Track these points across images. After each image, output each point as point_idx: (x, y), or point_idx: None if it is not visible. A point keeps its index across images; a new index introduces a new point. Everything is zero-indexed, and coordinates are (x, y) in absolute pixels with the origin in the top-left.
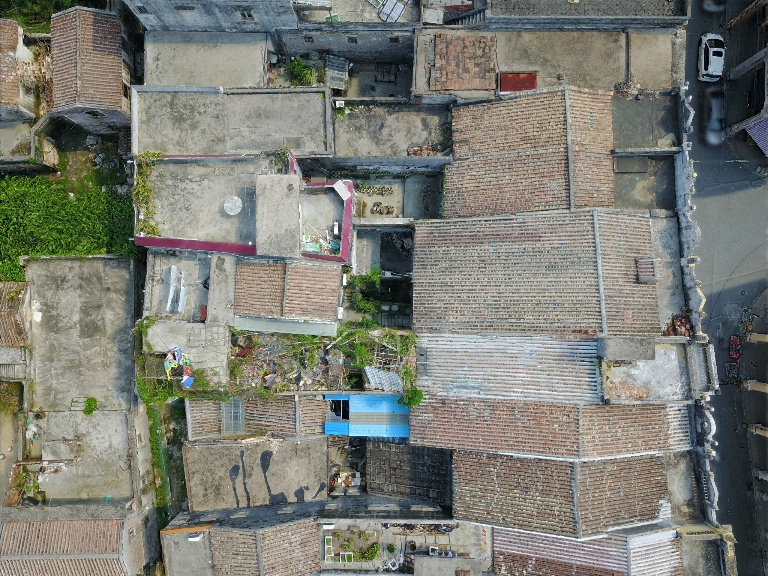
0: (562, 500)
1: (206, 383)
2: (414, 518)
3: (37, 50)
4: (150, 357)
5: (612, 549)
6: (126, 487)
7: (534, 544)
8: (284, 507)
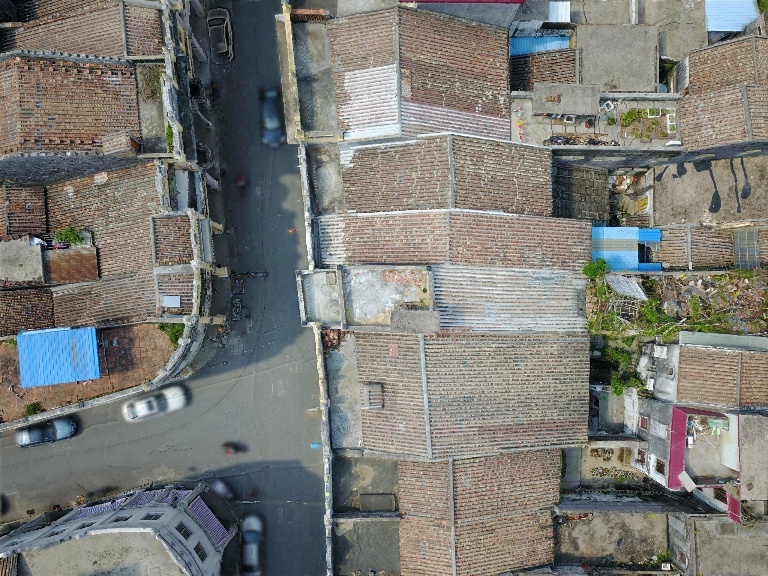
0: (463, 171)
1: None
2: None
3: None
4: None
5: (414, 123)
6: None
7: (477, 126)
8: None
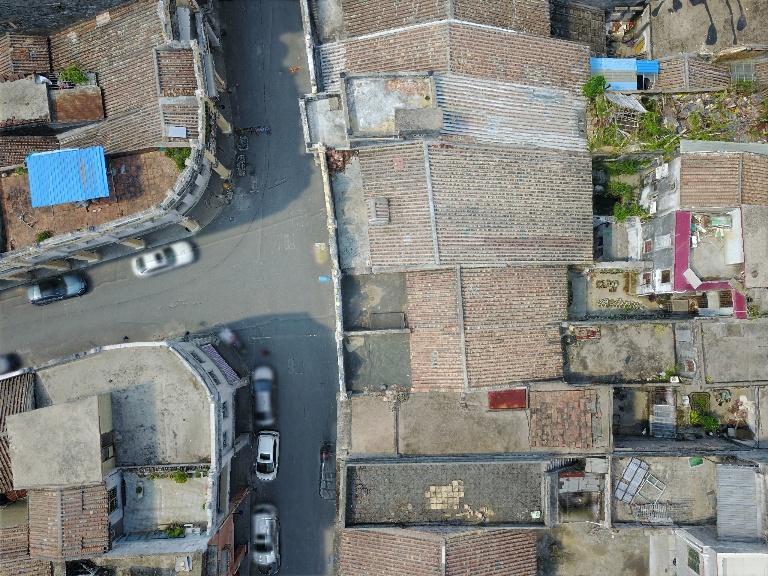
0: None
1: None
2: None
3: None
4: None
5: None
6: None
7: None
8: None
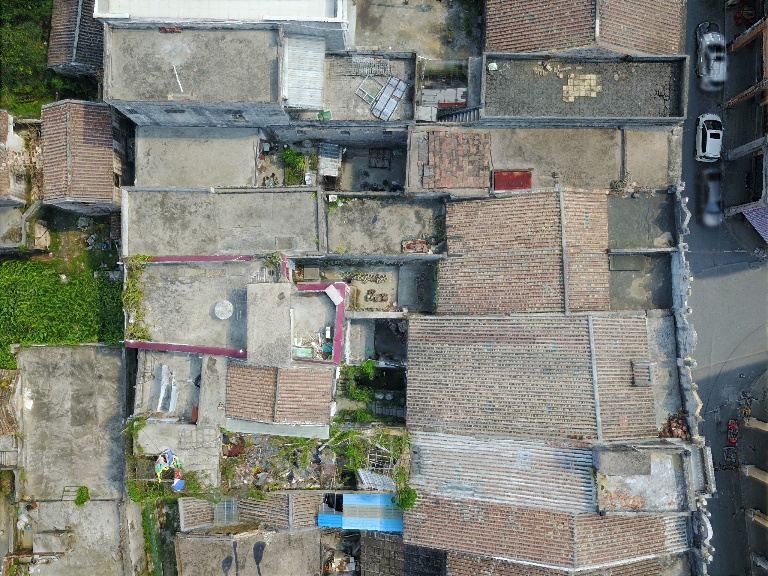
0: None
1: (197, 486)
2: None
3: (28, 135)
4: (141, 459)
5: None
6: None
7: None
8: None
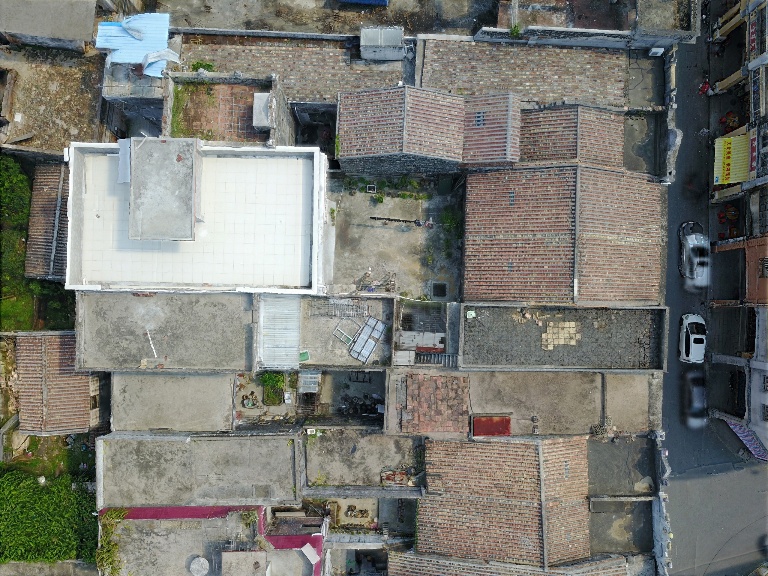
0: None
1: None
2: None
3: (5, 346)
4: None
5: None
6: None
7: None
8: None
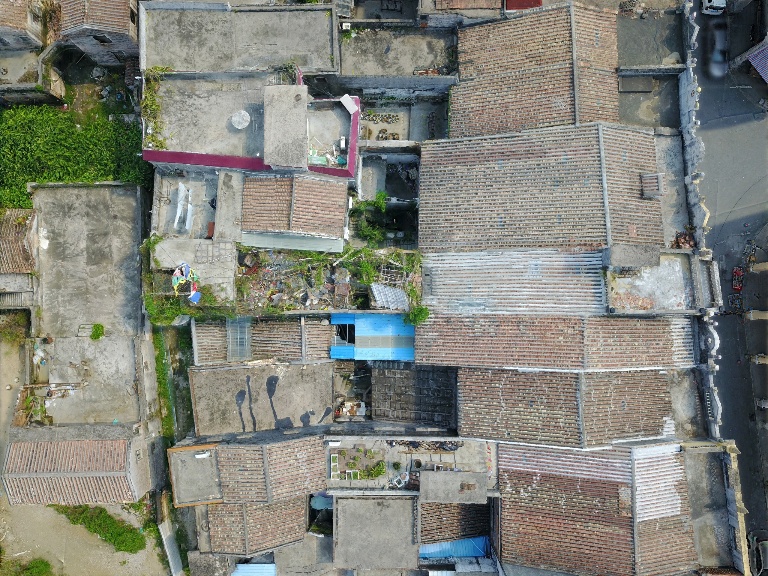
0: (567, 412)
1: (213, 299)
2: (420, 435)
3: None
4: (158, 273)
5: (616, 461)
6: (133, 412)
7: (539, 460)
8: (290, 430)
